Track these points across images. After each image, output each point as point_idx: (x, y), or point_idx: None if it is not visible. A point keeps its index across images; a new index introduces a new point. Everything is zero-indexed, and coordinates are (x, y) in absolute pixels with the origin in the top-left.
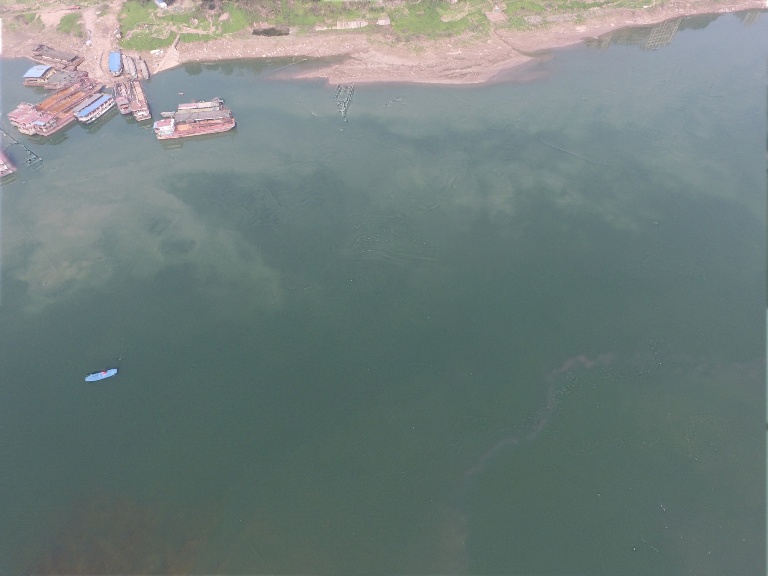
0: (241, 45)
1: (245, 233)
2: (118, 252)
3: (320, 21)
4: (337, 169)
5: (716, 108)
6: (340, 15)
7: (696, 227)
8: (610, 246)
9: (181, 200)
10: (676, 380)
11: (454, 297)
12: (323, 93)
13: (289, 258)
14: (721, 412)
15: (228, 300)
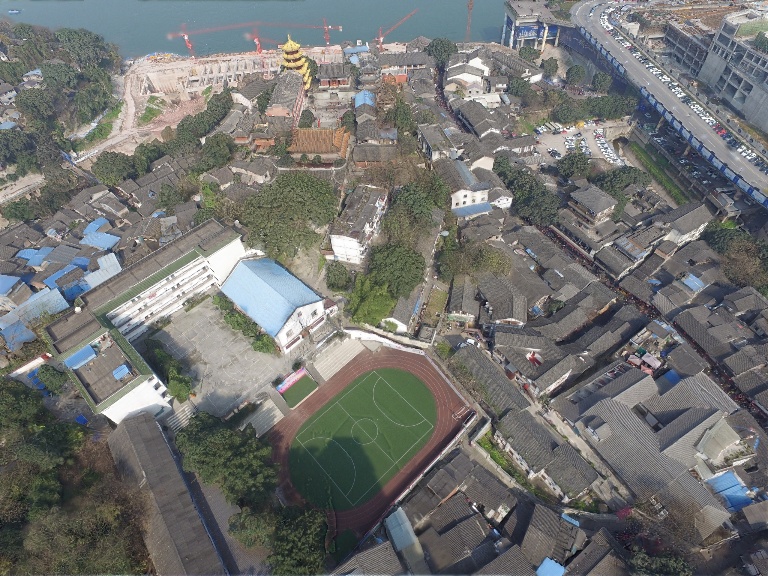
0: None
1: None
2: None
3: None
4: None
5: None
6: None
7: None
8: None
9: None
10: None
11: None
12: None
13: None
14: (233, 3)
15: None
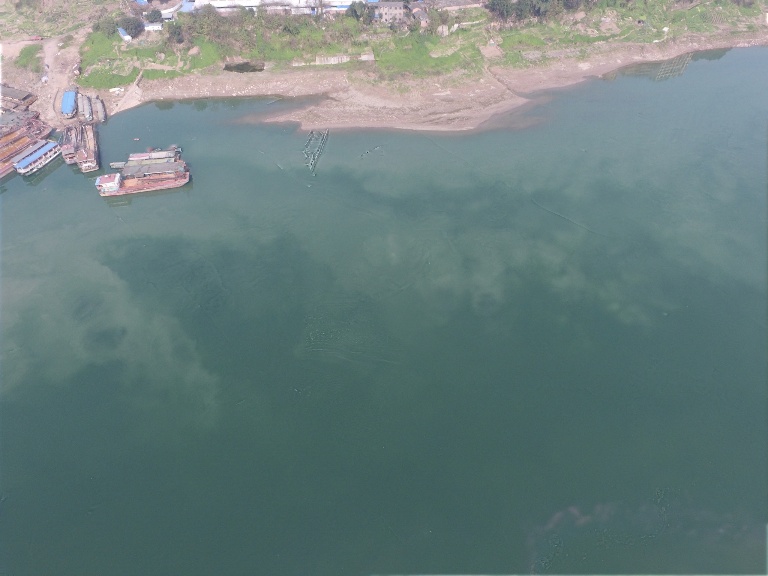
0: (210, 82)
1: (180, 322)
2: (32, 342)
3: (298, 56)
4: (296, 239)
5: (735, 163)
6: (320, 49)
7: (713, 326)
8: (609, 346)
9: (116, 274)
10: (688, 549)
11: (417, 417)
12: (293, 140)
13: (229, 354)
14: None
15: (147, 415)
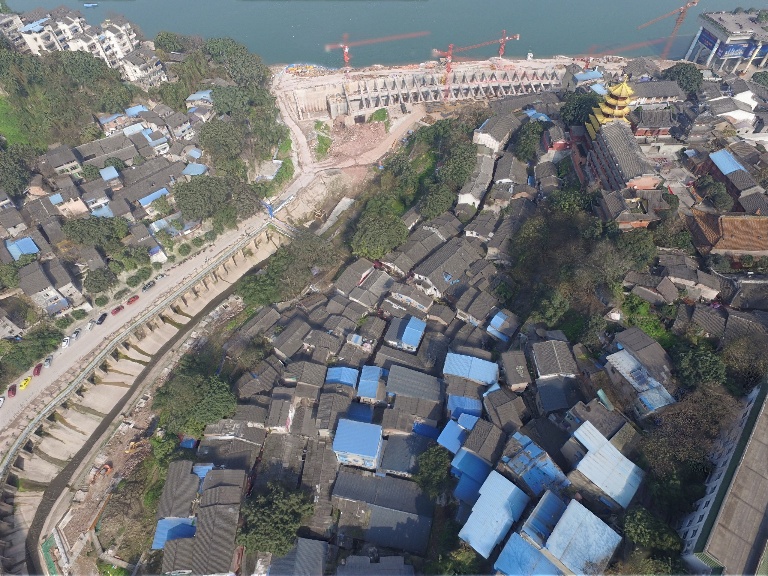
0: None
1: None
2: None
3: None
4: None
5: None
6: None
7: None
8: None
9: None
10: None
11: None
12: None
13: None
14: None
15: None
